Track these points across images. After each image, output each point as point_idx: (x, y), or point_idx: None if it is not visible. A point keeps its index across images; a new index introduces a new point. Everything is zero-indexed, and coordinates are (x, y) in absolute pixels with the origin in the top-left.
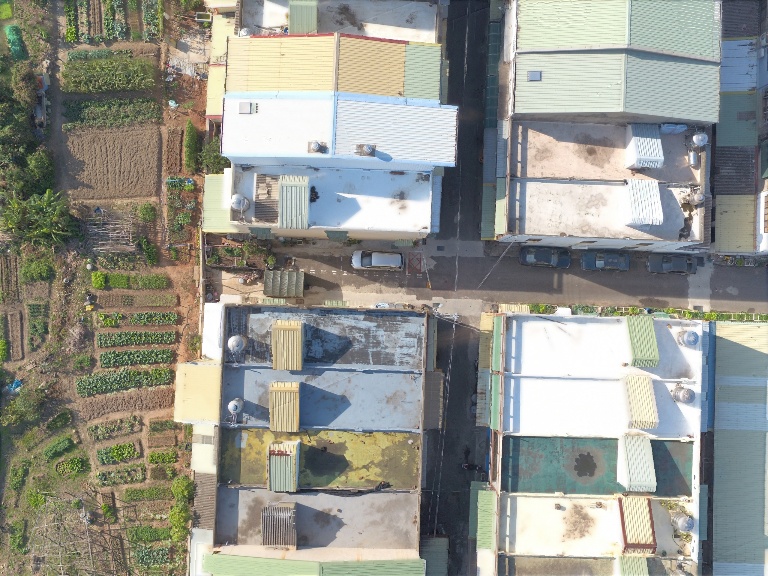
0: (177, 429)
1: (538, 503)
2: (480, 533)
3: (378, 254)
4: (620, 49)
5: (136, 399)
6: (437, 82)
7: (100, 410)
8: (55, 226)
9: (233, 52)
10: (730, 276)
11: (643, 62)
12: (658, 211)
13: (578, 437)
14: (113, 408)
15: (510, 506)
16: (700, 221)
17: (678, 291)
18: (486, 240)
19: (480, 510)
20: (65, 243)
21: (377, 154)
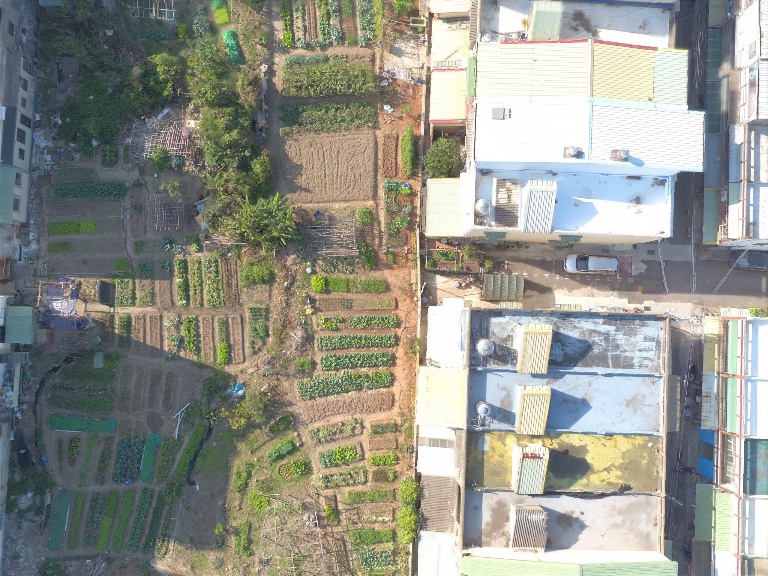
0: (397, 432)
1: None
2: (718, 535)
3: (594, 258)
4: None
5: (357, 402)
6: (685, 88)
7: (321, 413)
8: (284, 230)
9: (482, 58)
10: None
11: None
12: None
13: None
14: (334, 411)
15: (749, 508)
16: None
17: None
18: (697, 244)
19: (718, 512)
20: (285, 247)
21: (630, 159)
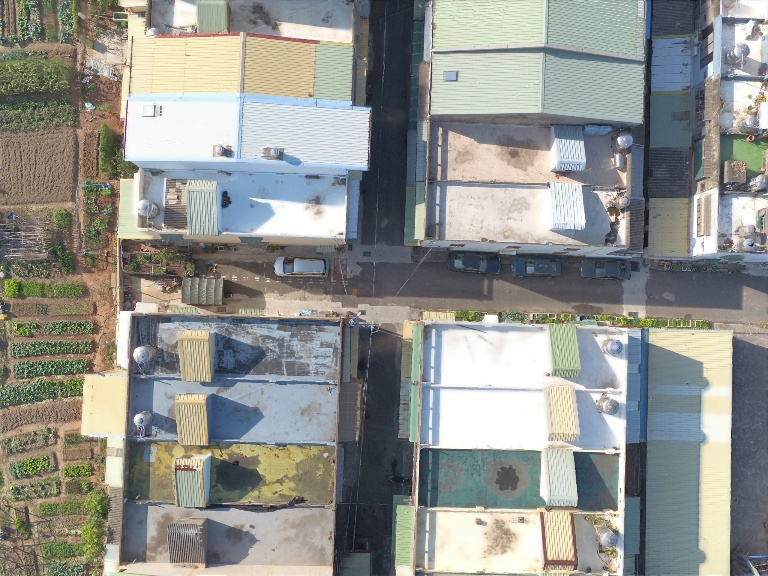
0: (93, 441)
1: (458, 518)
2: (398, 549)
3: (300, 260)
4: (538, 48)
5: (51, 411)
6: (349, 83)
7: (13, 422)
8: None
9: (138, 53)
10: (666, 281)
11: (562, 61)
12: (580, 215)
13: (500, 449)
14: (27, 420)
15: (429, 521)
16: (626, 225)
17: (612, 297)
18: None
19: (398, 525)
20: None
21: (285, 158)
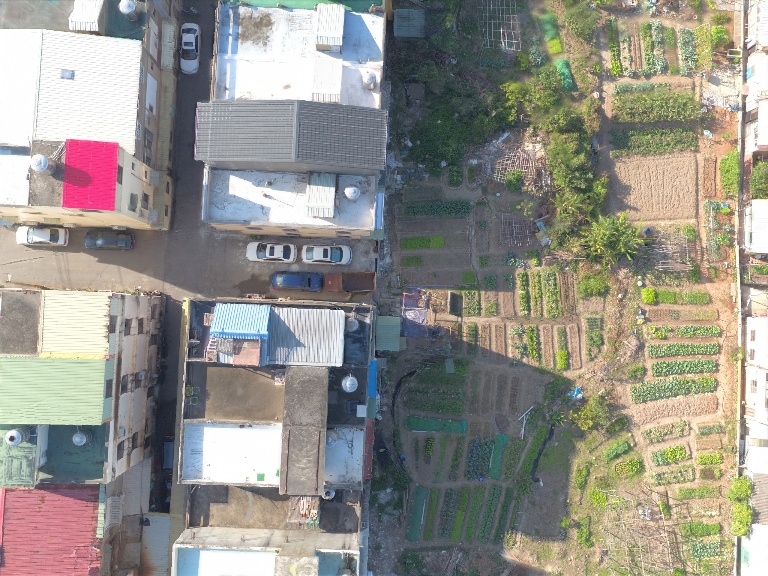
0: (722, 433)
1: None
2: None
3: None
4: None
5: (685, 405)
6: None
7: (652, 415)
8: (630, 247)
9: None
10: None
11: None
12: None
13: None
14: (664, 414)
15: None
16: None
17: None
18: None
19: None
20: (617, 261)
21: None
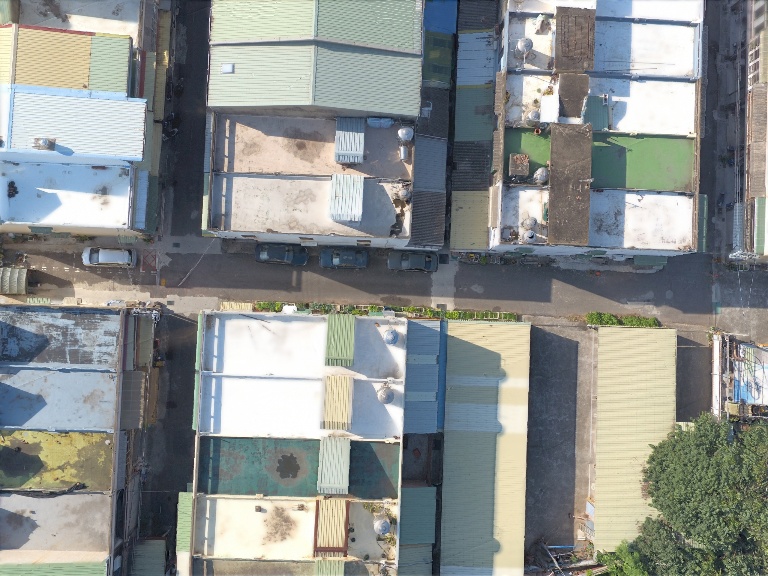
0: None
1: (238, 505)
2: (179, 535)
3: (106, 251)
4: (310, 41)
5: None
6: (125, 74)
7: None
8: None
9: None
10: (475, 274)
11: (335, 54)
12: (358, 207)
13: (280, 438)
14: None
15: (209, 508)
16: (409, 217)
17: (421, 289)
18: None
19: (180, 512)
20: None
21: (57, 148)
